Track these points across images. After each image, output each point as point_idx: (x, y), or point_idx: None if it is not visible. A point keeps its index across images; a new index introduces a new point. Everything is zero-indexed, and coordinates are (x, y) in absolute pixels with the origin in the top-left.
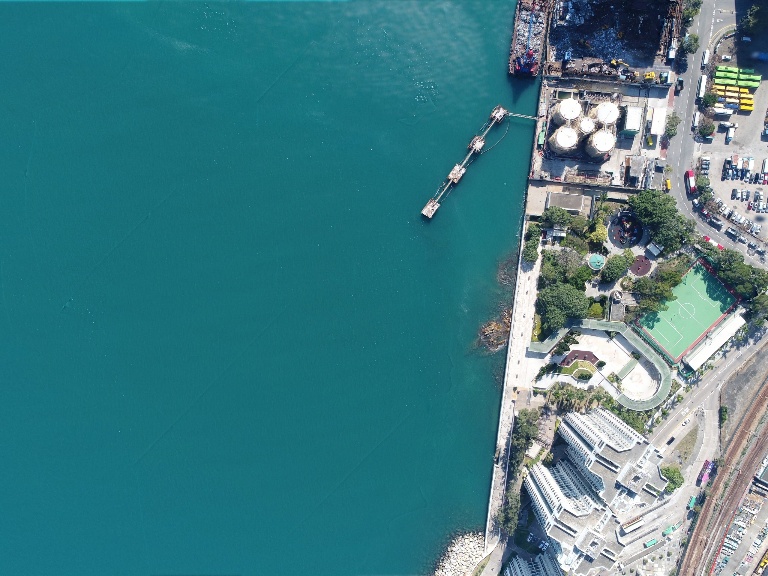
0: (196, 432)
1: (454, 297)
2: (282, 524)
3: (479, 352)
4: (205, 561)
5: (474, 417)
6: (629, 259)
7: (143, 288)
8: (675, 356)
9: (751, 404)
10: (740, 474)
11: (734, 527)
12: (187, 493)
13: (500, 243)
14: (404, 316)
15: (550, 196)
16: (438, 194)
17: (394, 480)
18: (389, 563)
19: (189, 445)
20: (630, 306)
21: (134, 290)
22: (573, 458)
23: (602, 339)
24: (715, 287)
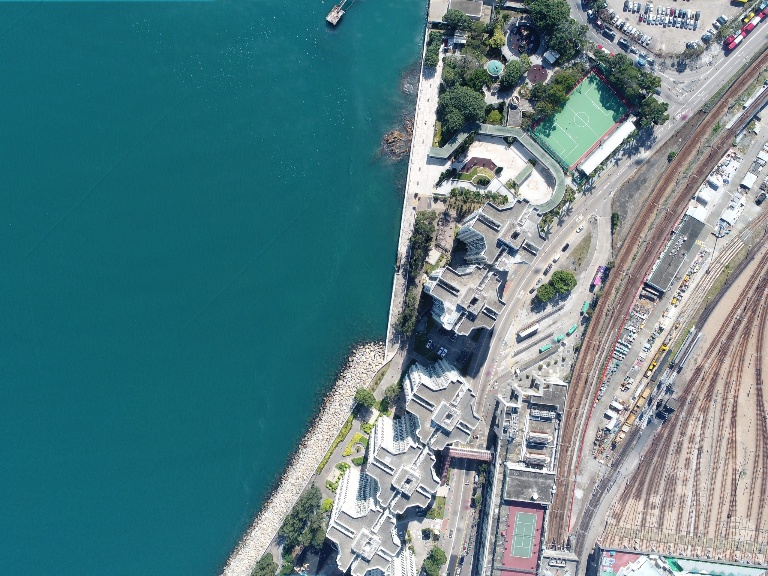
0: (90, 224)
1: (358, 106)
2: (177, 318)
3: (382, 162)
4: (99, 364)
5: (376, 226)
6: (525, 63)
7: (37, 74)
8: (570, 164)
9: (641, 210)
10: (630, 278)
11: (625, 332)
12: (80, 289)
13: (403, 52)
14: (303, 107)
15: (450, 1)
16: (342, 0)
17: (291, 274)
18: (291, 376)
19: (82, 237)
20: (527, 112)
21: (28, 76)
22: (468, 254)
23: (500, 147)
24: (608, 97)
